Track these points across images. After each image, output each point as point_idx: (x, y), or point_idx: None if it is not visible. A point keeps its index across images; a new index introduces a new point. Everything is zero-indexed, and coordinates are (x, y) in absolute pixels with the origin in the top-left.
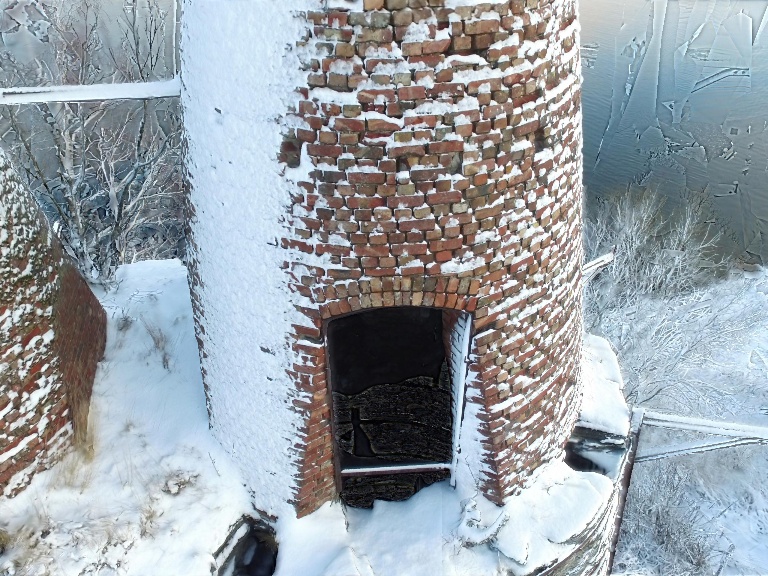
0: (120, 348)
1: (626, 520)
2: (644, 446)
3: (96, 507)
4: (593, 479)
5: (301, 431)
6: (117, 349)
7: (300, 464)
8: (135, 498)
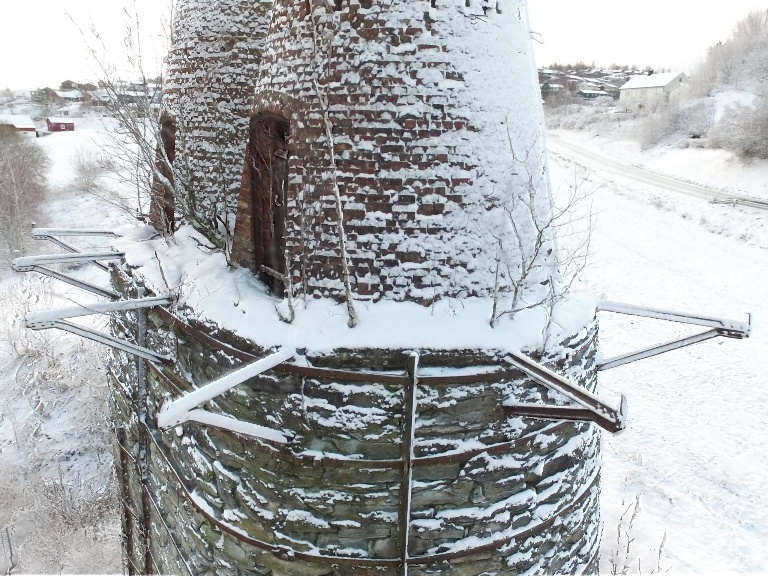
0: None
1: None
2: None
3: None
4: None
5: None
6: None
7: None
8: None
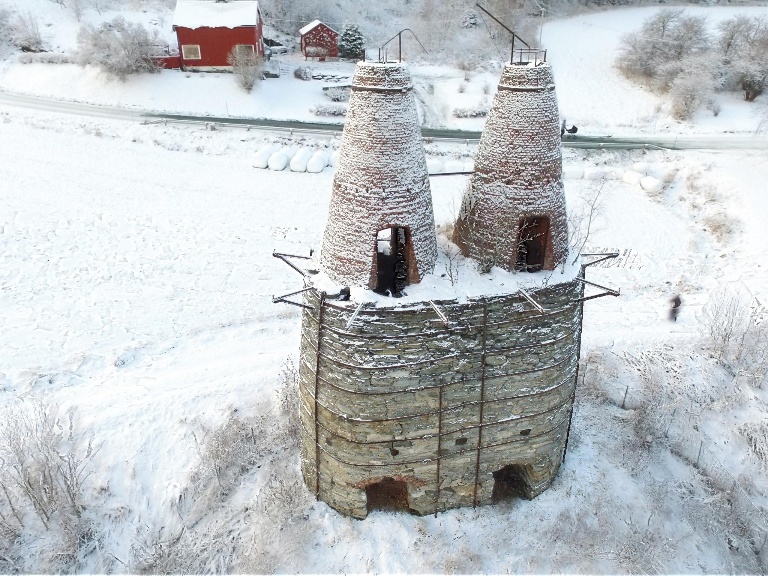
0: None
1: (190, 575)
2: None
3: None
4: None
5: None
6: None
7: None
8: None
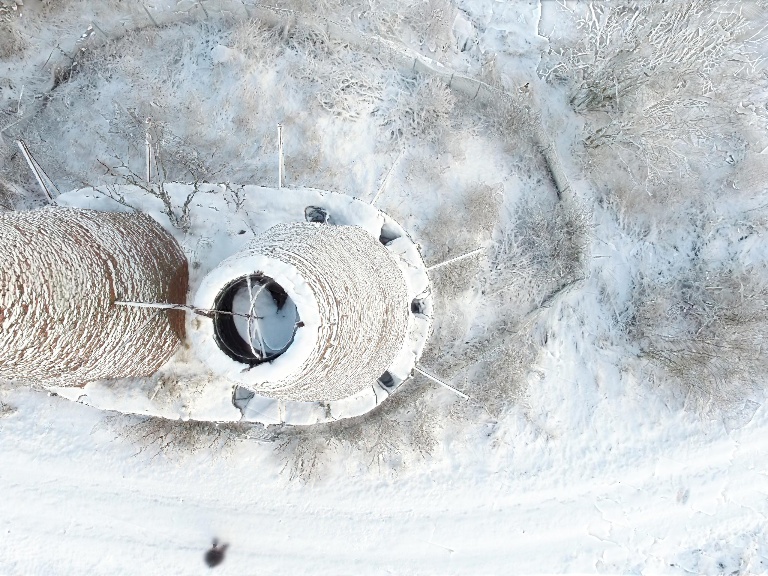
0: (195, 281)
1: (536, 238)
2: (605, 166)
3: (193, 370)
4: (380, 394)
5: None
6: (194, 282)
7: None
8: (206, 368)
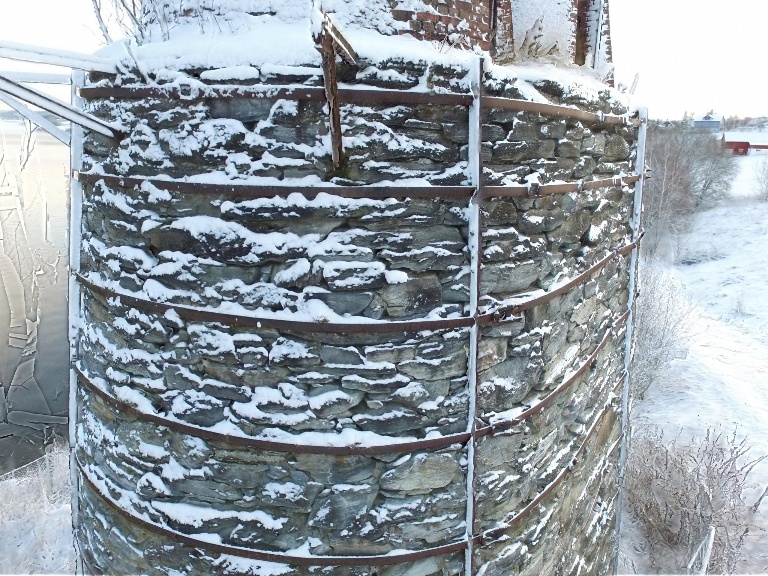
0: None
1: None
2: None
3: None
4: None
5: (574, 33)
6: None
7: (574, 56)
8: None
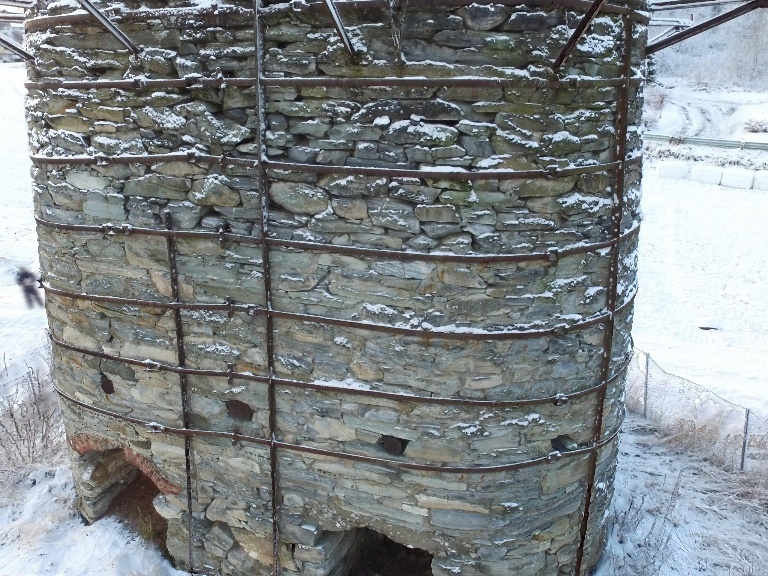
0: None
1: None
2: None
3: None
4: None
5: None
6: None
7: None
8: None
